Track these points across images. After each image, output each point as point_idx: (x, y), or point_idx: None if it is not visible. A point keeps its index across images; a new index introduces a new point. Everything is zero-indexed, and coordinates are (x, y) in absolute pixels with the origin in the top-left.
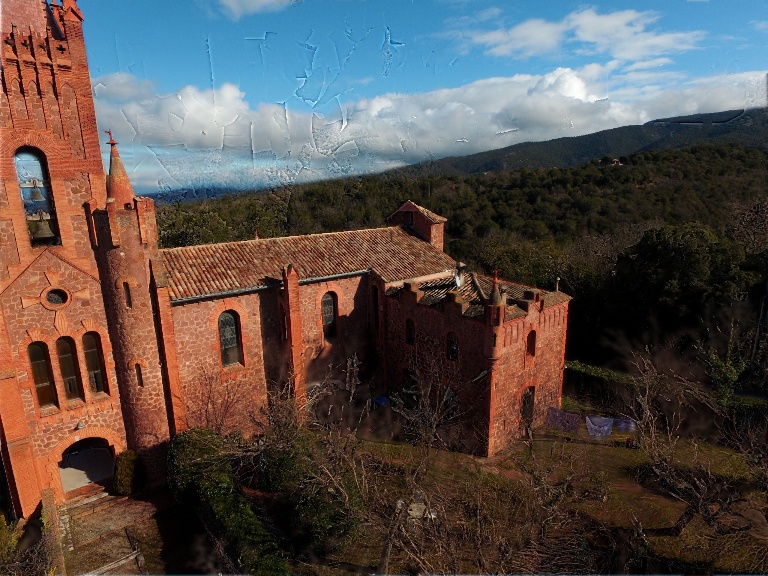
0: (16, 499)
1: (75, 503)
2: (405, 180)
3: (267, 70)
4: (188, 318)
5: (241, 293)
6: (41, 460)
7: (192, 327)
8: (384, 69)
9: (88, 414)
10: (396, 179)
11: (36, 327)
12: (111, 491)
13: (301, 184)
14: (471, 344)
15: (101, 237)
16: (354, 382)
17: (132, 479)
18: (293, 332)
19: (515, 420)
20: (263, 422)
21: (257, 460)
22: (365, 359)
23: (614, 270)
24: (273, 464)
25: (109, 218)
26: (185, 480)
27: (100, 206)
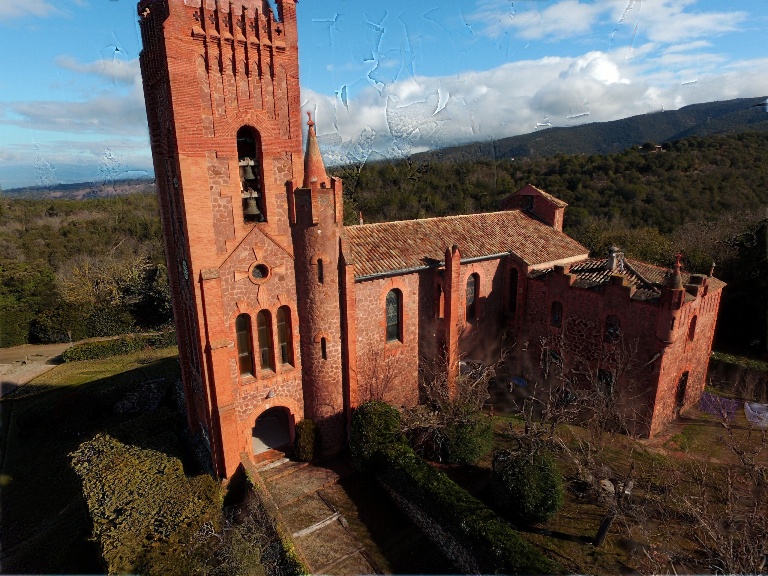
0: (219, 460)
1: (263, 467)
2: (472, 164)
3: (335, 52)
4: (363, 295)
5: (407, 272)
6: (239, 425)
7: (366, 304)
8: (629, 50)
9: (277, 384)
10: (463, 163)
11: (243, 300)
12: (291, 457)
13: (369, 167)
14: (637, 327)
15: (300, 215)
16: (548, 360)
17: (313, 447)
18: (452, 311)
19: (671, 404)
20: (413, 398)
21: (420, 433)
22: (497, 340)
23: (737, 258)
24: (452, 437)
25: (312, 196)
26: (372, 449)
27: (298, 185)
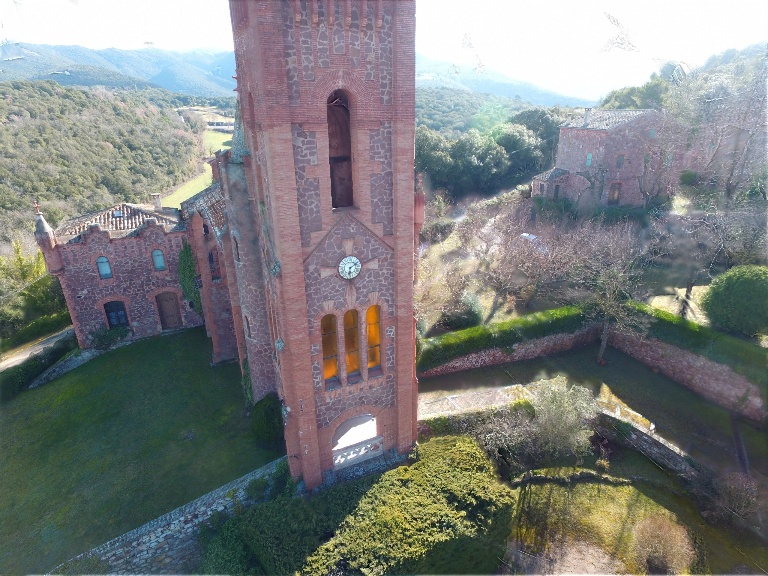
0: None
1: None
2: None
3: None
4: None
5: None
6: None
7: None
8: None
9: None
10: None
11: None
12: None
13: None
14: None
15: None
16: None
17: None
18: None
19: None
20: None
21: None
22: None
23: None
24: None
25: None
26: None
27: None
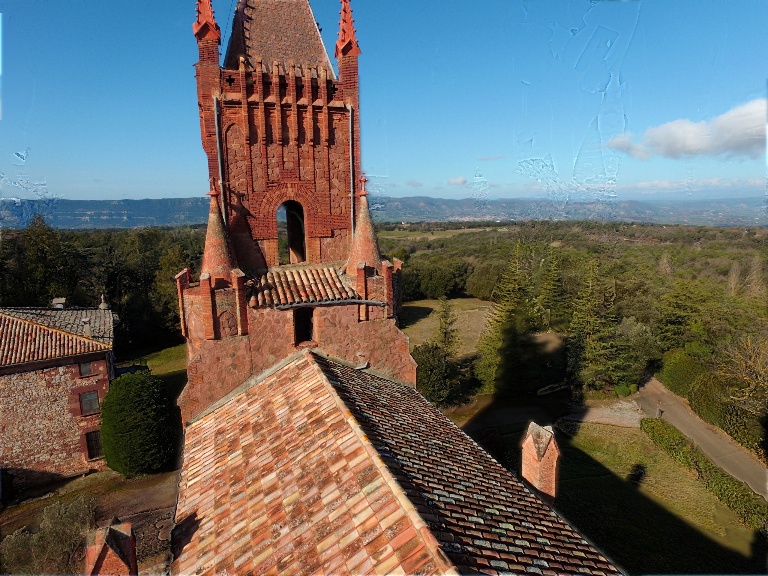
0: None
1: None
2: None
3: None
4: None
5: None
6: None
7: None
8: None
9: None
10: None
11: None
12: None
13: None
14: None
15: None
16: None
17: None
18: None
19: None
20: None
21: None
22: None
23: None
24: None
25: None
26: None
27: None
